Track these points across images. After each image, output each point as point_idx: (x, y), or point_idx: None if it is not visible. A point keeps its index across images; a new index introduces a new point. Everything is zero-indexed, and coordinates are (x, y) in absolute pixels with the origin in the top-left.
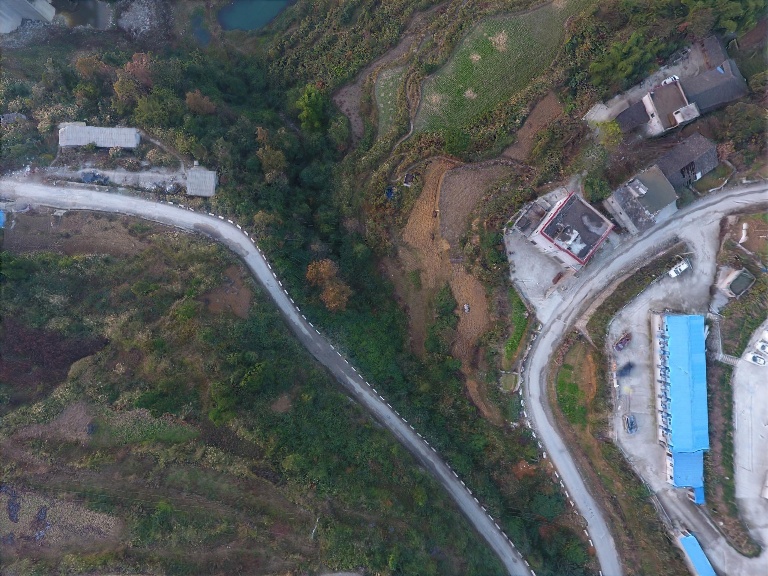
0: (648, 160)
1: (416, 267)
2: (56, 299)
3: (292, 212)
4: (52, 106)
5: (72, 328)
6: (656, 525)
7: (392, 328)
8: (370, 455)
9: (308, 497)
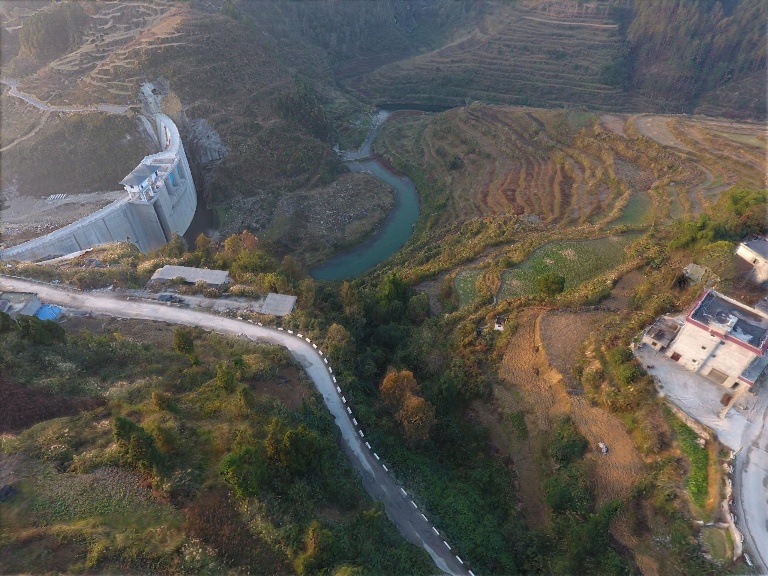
0: None
1: (518, 409)
2: (67, 364)
3: (364, 353)
4: None
5: (66, 388)
6: None
7: (489, 493)
8: None
9: None
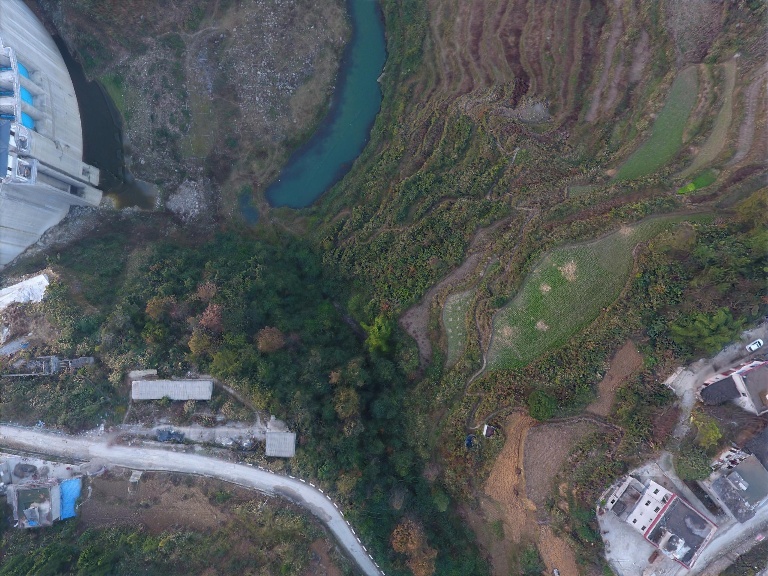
0: (738, 431)
1: (498, 518)
2: None
3: (368, 454)
4: (122, 352)
5: None
6: None
7: (474, 575)
8: None
9: None
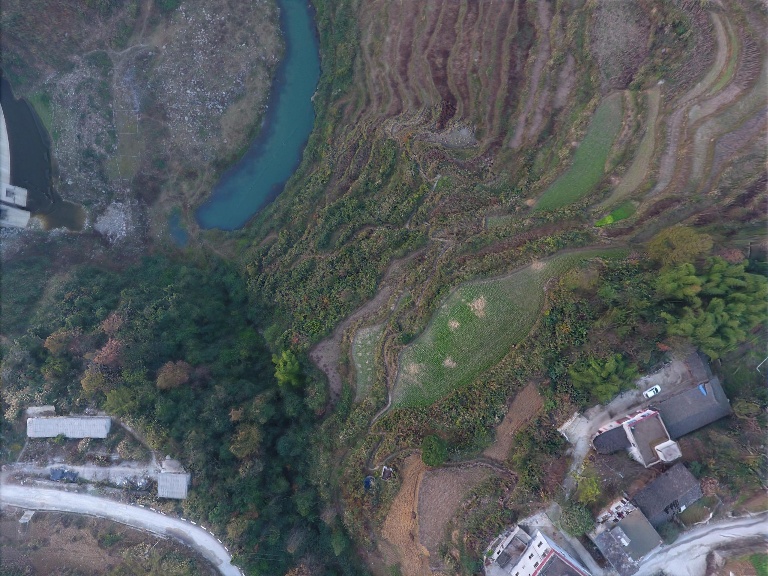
0: (631, 481)
1: (396, 561)
2: None
3: (268, 493)
4: (20, 388)
5: None
6: None
7: None
8: None
9: None
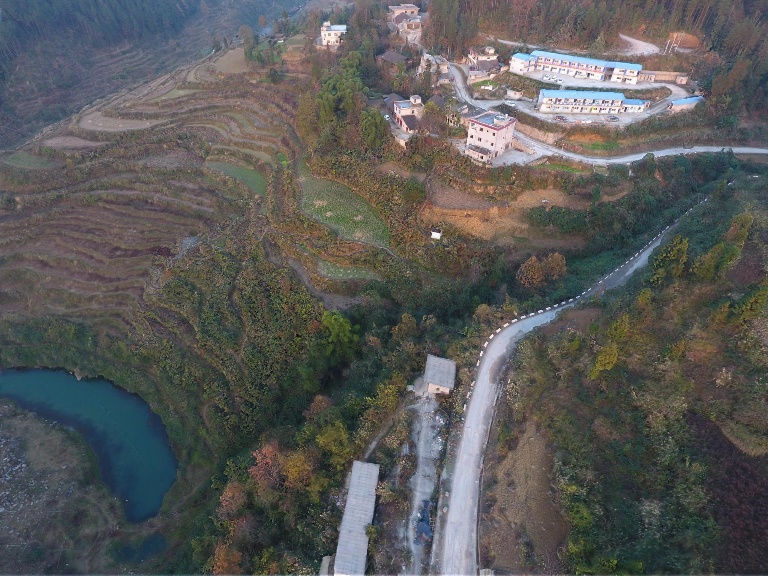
0: None
1: (510, 238)
2: (651, 507)
3: None
4: None
5: None
6: (671, 117)
7: None
8: (700, 219)
9: (767, 218)
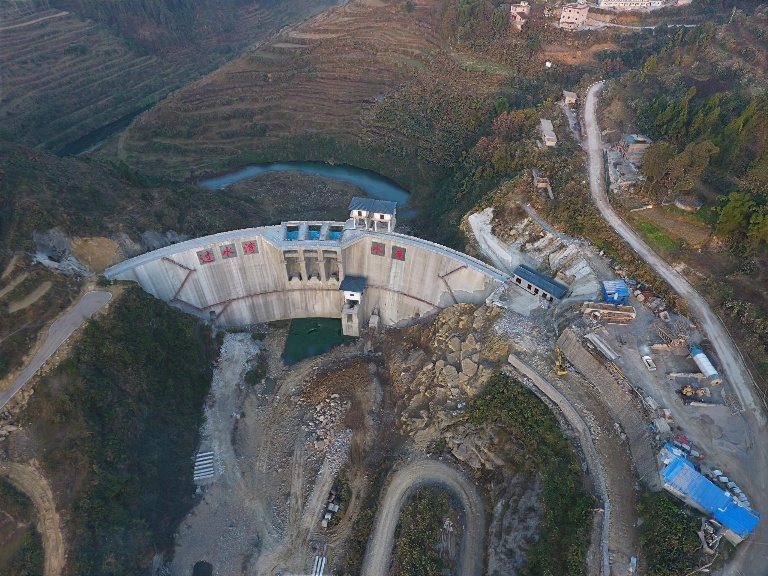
0: None
1: None
2: None
3: None
4: None
5: None
6: (677, 7)
7: None
8: None
9: None
